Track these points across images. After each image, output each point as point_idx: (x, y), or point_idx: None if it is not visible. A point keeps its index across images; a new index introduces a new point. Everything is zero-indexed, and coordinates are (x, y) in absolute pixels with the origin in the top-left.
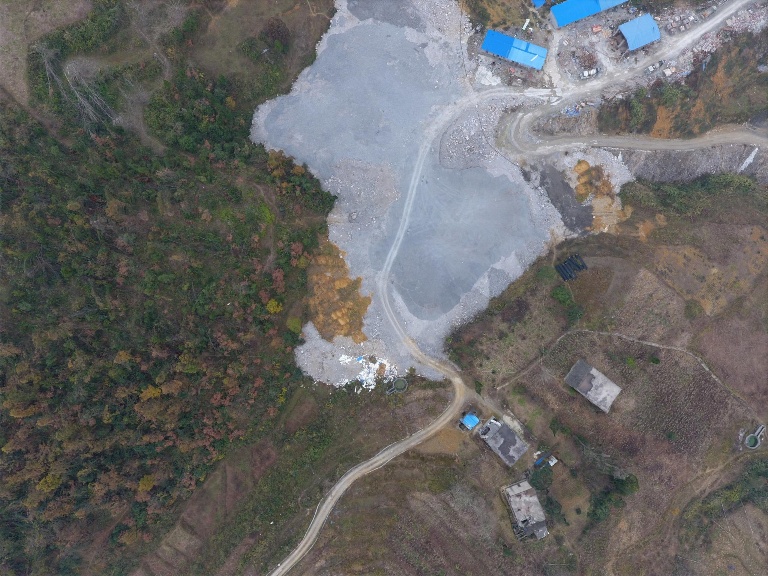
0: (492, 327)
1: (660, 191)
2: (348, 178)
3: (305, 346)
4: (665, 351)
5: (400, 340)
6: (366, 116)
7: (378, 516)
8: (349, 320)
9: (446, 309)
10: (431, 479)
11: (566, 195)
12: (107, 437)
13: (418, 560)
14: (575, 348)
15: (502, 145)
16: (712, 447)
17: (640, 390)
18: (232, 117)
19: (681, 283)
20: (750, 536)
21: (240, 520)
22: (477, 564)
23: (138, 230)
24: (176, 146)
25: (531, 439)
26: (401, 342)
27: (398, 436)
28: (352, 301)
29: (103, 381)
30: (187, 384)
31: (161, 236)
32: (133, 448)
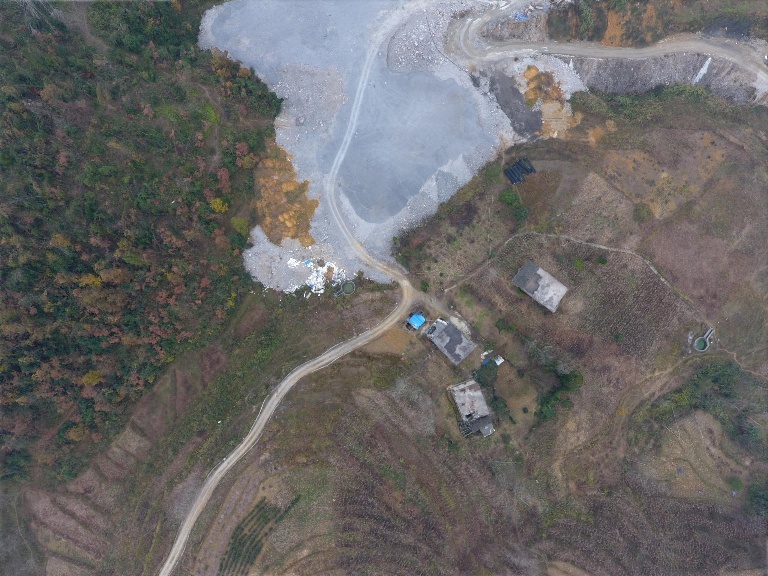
0: (440, 231)
1: (613, 102)
2: (296, 84)
3: (253, 249)
4: (613, 253)
5: (348, 244)
6: (313, 21)
7: (323, 411)
8: (296, 222)
9: (393, 211)
10: (376, 376)
11: (515, 101)
12: (48, 326)
13: (362, 453)
14: (523, 250)
15: (451, 51)
16: (661, 349)
17: (588, 292)
18: (178, 20)
19: (630, 187)
20: (700, 441)
21: (189, 421)
22: (422, 458)
23: (79, 124)
24: (120, 47)
25: (478, 340)
26: (349, 246)
27: (345, 336)
28: (299, 203)
29: (44, 271)
30: (129, 276)
31: (102, 129)
32: (76, 340)
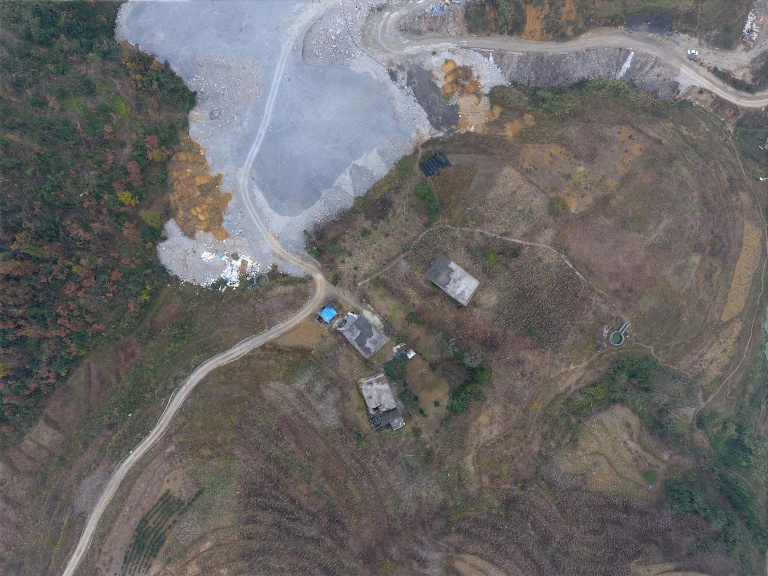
0: (355, 225)
1: (536, 96)
2: (212, 77)
3: (167, 243)
4: (528, 247)
5: (263, 237)
6: (229, 14)
7: (229, 403)
8: (209, 216)
9: (307, 205)
10: (285, 369)
11: (433, 94)
12: None
13: (268, 446)
14: (436, 244)
15: (369, 45)
16: (575, 343)
17: (502, 286)
18: (92, 14)
19: (546, 181)
20: (618, 435)
21: (101, 414)
22: (329, 451)
23: None
24: (31, 40)
25: (391, 333)
26: (264, 239)
27: (256, 329)
28: (212, 197)
29: None
30: (31, 268)
31: (6, 122)
32: None
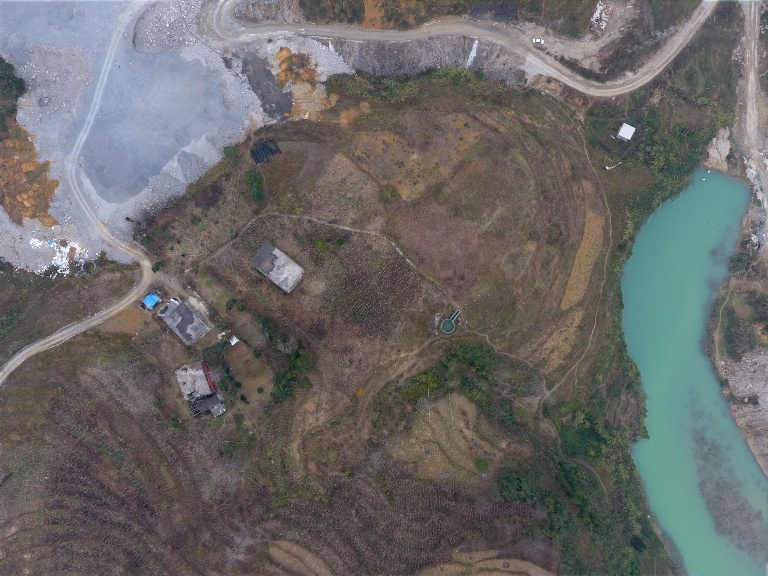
0: (186, 212)
1: (380, 84)
2: (44, 64)
3: None
4: (357, 235)
5: (92, 224)
6: (60, 1)
7: (43, 389)
8: (35, 202)
9: (134, 192)
10: (103, 355)
11: (267, 82)
12: None
13: (80, 432)
14: (264, 231)
15: (204, 32)
16: (405, 331)
17: (330, 273)
18: None
19: (378, 168)
20: (453, 423)
21: None
22: (143, 437)
23: None
24: None
25: (216, 320)
26: (93, 226)
27: (79, 316)
28: (38, 183)
29: None
30: None
31: None
32: None
